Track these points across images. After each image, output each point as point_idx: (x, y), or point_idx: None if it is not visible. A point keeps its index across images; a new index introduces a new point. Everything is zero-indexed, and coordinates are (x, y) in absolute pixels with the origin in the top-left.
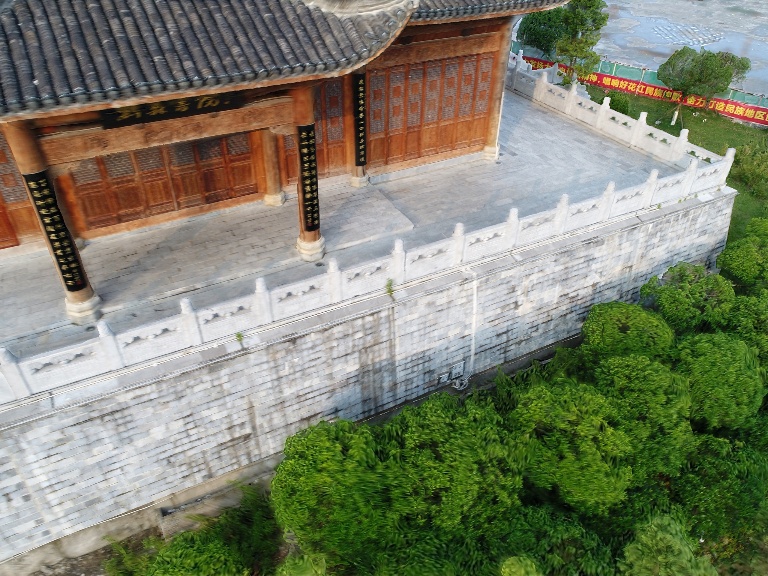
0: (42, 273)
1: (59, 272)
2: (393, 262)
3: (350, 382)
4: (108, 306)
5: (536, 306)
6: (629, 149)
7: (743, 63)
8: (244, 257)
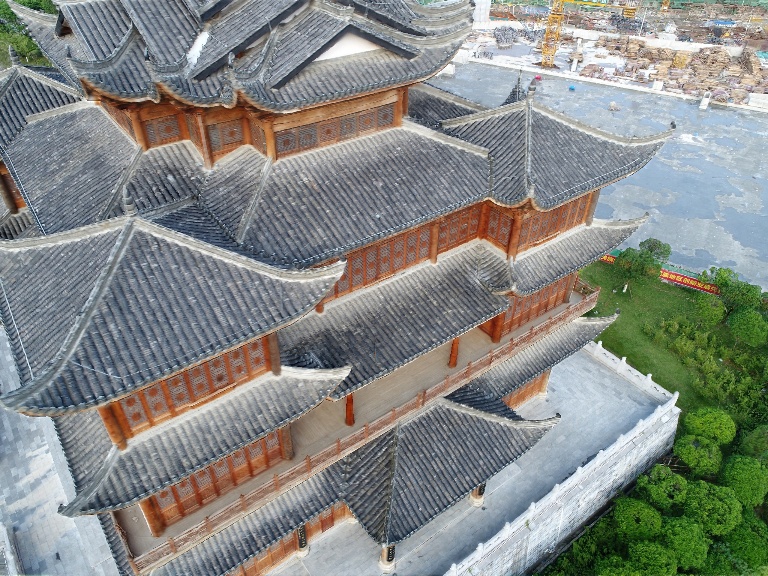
0: (349, 540)
1: (386, 555)
2: (530, 513)
3: (508, 570)
4: (398, 560)
5: (587, 502)
6: (616, 375)
7: (667, 251)
8: (446, 511)
